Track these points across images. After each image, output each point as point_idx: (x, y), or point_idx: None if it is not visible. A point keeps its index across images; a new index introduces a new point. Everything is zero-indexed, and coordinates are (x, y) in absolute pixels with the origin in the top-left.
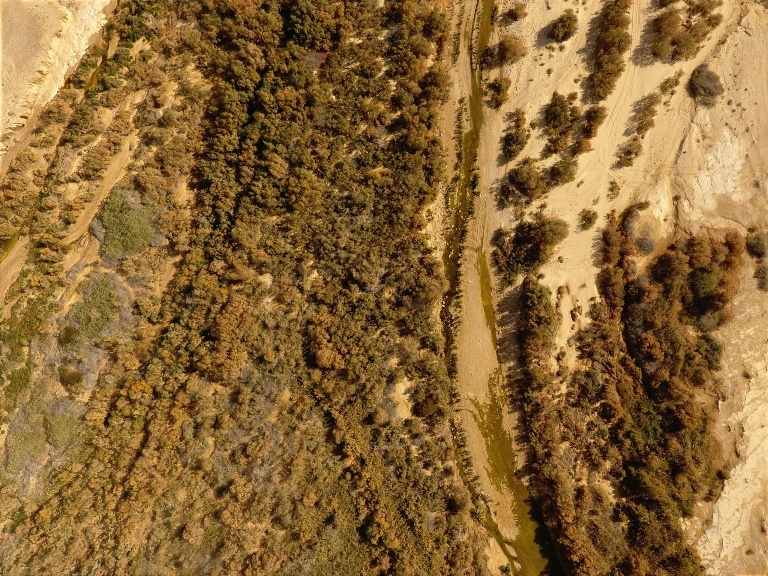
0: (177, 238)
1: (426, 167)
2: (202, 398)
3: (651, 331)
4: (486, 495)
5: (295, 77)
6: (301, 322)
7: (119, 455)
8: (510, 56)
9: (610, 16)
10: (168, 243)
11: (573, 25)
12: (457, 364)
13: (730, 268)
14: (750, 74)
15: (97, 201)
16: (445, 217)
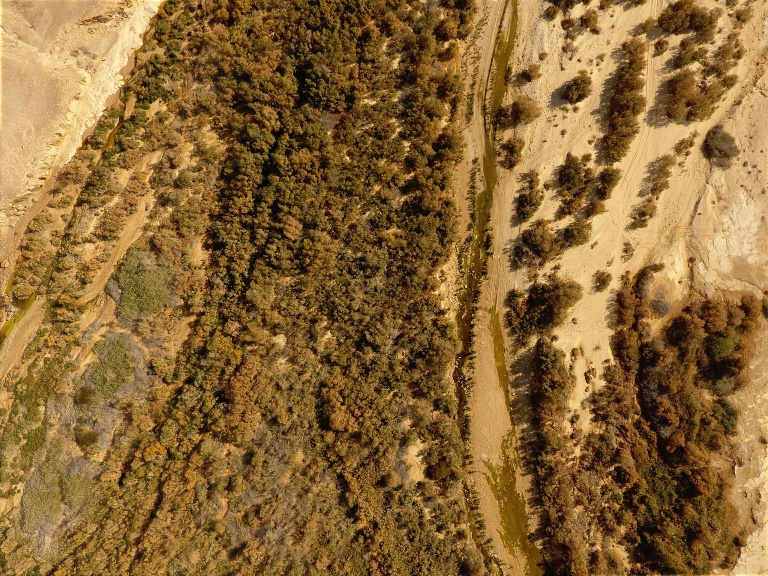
0: (192, 300)
1: (440, 229)
2: (216, 460)
3: (666, 395)
4: (499, 558)
5: (310, 140)
6: (314, 384)
7: (133, 516)
8: (524, 118)
9: (624, 79)
10: (183, 303)
11: (587, 88)
12: (470, 425)
13: (746, 332)
14: (766, 136)
15: (113, 261)
16: (458, 277)
